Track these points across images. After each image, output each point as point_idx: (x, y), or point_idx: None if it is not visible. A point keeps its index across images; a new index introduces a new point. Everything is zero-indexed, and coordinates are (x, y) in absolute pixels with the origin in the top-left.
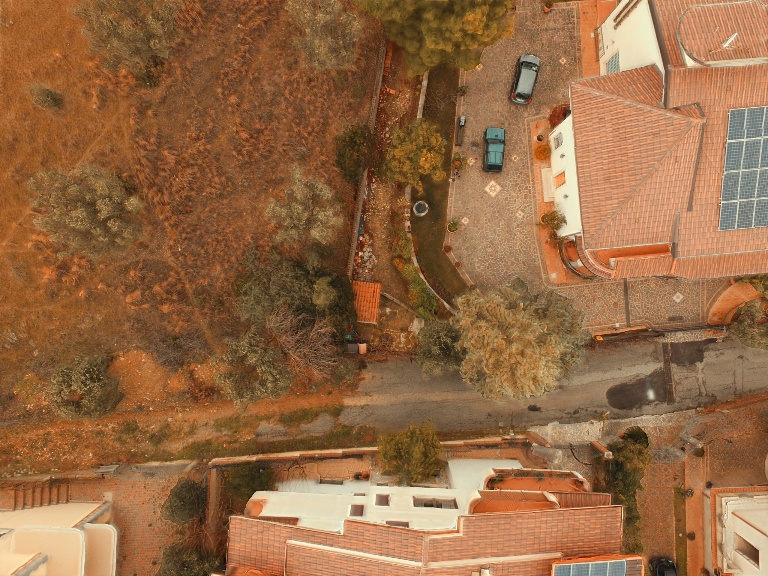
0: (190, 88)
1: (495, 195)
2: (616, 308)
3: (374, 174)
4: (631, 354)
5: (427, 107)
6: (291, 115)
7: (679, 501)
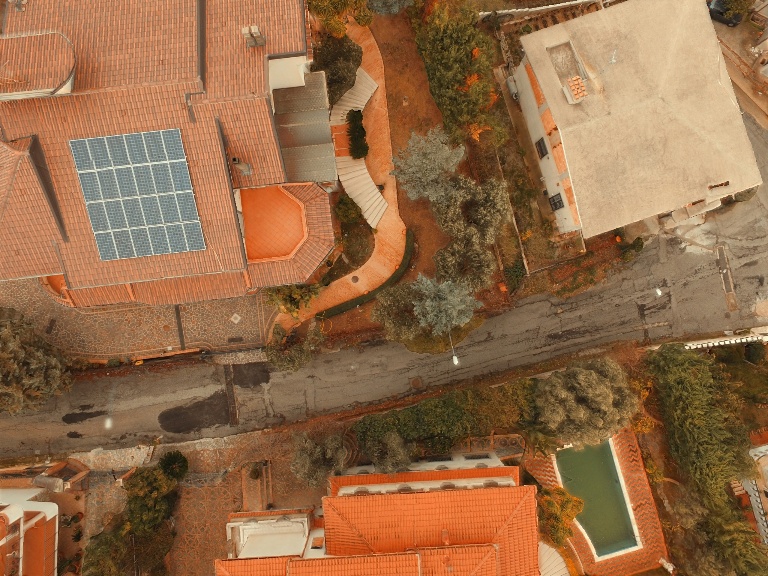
0: None
1: None
2: (167, 331)
3: None
4: (187, 377)
5: None
6: None
7: None
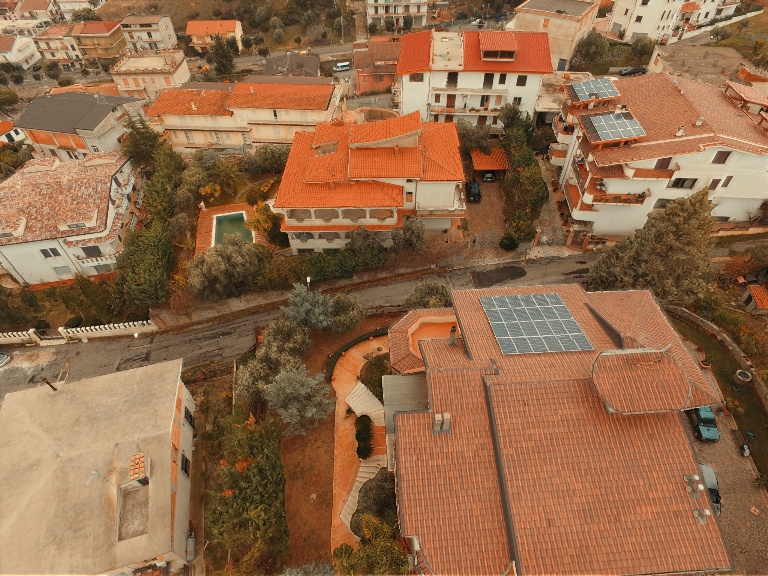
0: None
1: None
2: None
3: None
4: None
5: None
6: None
7: (465, 225)
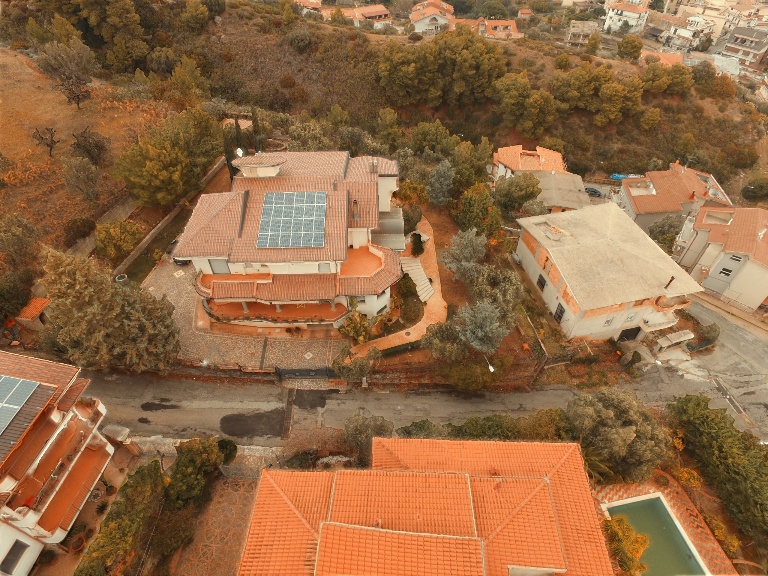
0: (4, 201)
1: (179, 277)
2: (253, 357)
3: (94, 252)
4: (256, 392)
5: (158, 237)
6: (54, 216)
7: None
